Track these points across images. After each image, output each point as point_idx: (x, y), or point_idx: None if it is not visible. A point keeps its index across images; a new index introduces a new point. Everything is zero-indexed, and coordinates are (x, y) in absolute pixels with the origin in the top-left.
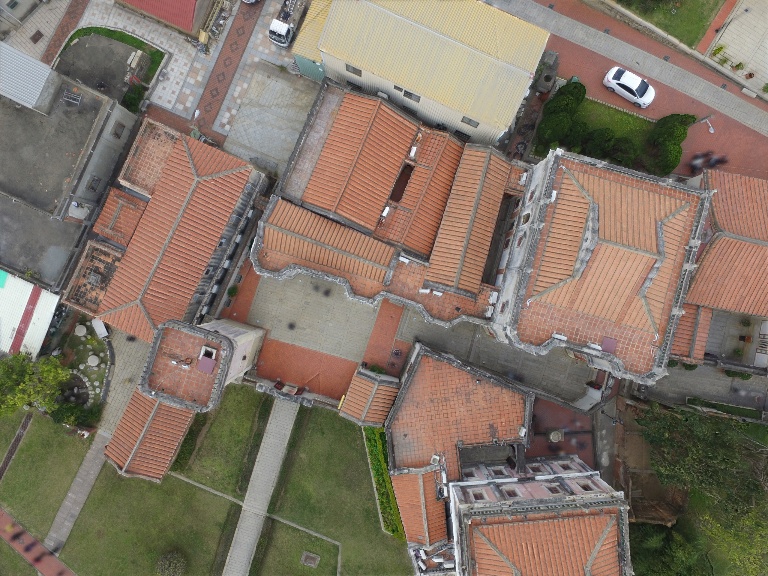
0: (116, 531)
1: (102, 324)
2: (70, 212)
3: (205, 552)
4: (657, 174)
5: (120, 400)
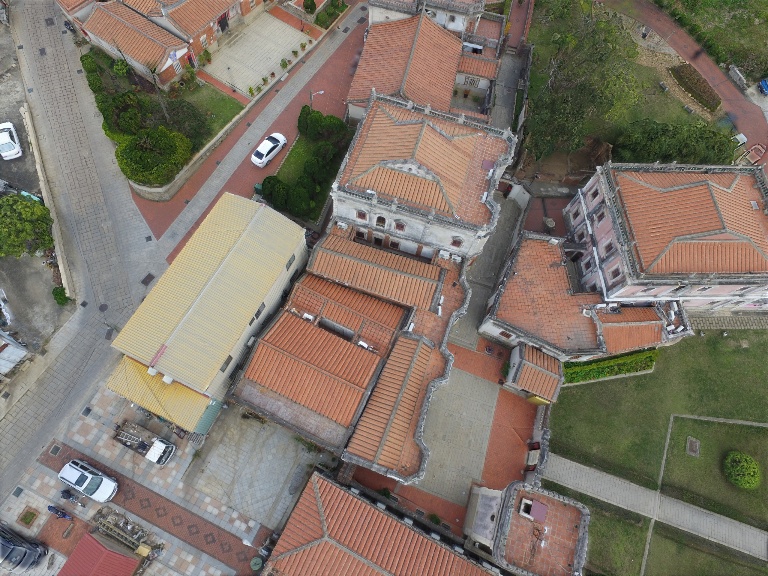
0: None
1: None
2: None
3: (711, 567)
4: (345, 133)
5: None
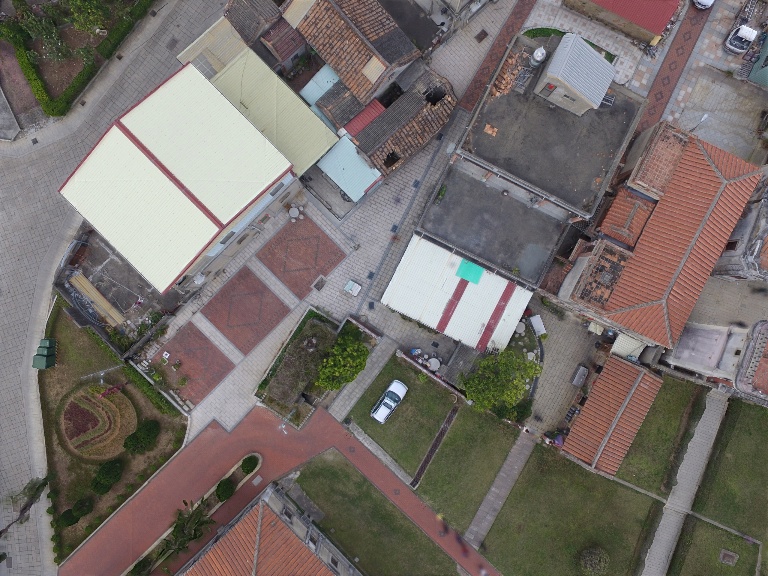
0: (536, 526)
1: (541, 322)
2: (550, 211)
3: (625, 548)
4: None
5: (547, 397)
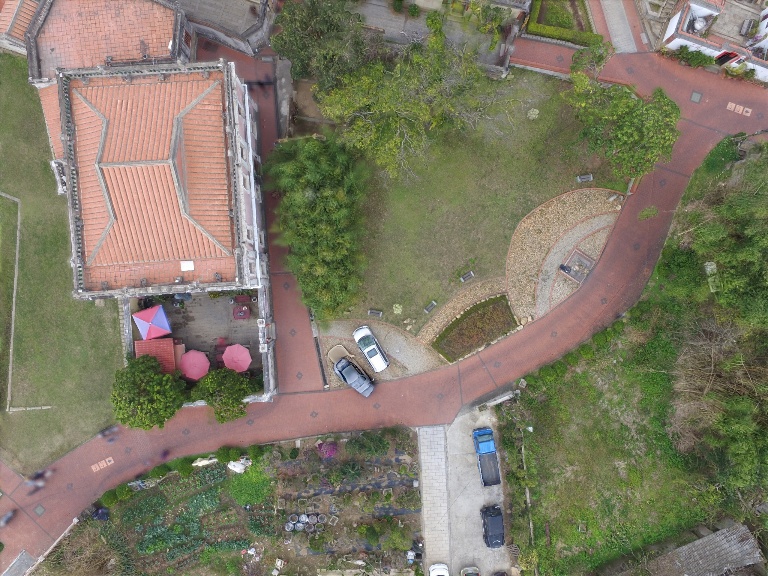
0: None
1: None
2: None
3: None
4: None
5: None
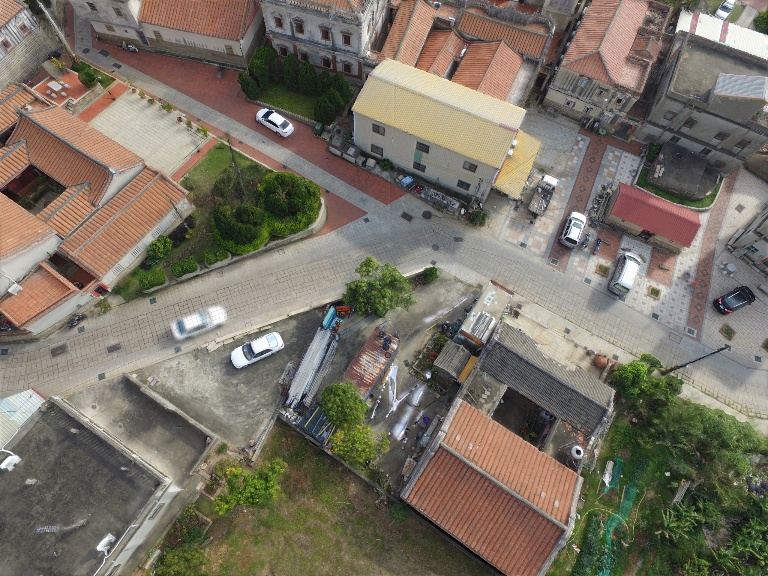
0: None
1: None
2: None
3: None
4: None
5: None
